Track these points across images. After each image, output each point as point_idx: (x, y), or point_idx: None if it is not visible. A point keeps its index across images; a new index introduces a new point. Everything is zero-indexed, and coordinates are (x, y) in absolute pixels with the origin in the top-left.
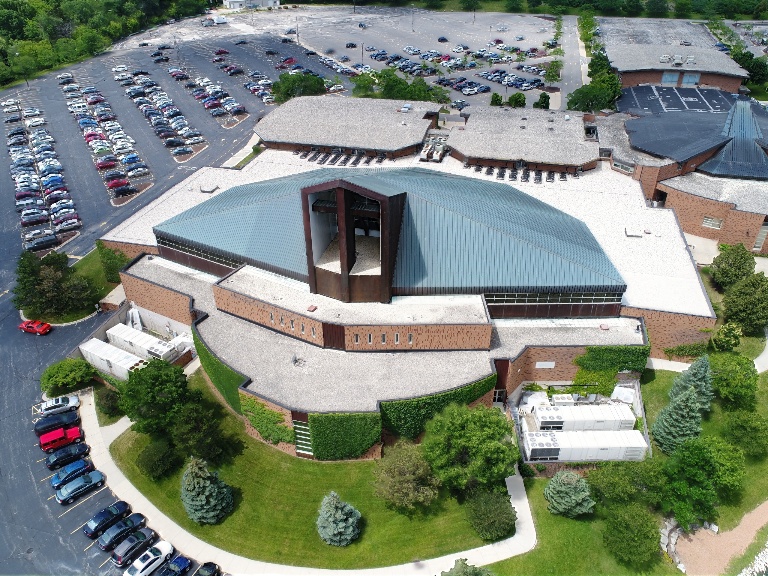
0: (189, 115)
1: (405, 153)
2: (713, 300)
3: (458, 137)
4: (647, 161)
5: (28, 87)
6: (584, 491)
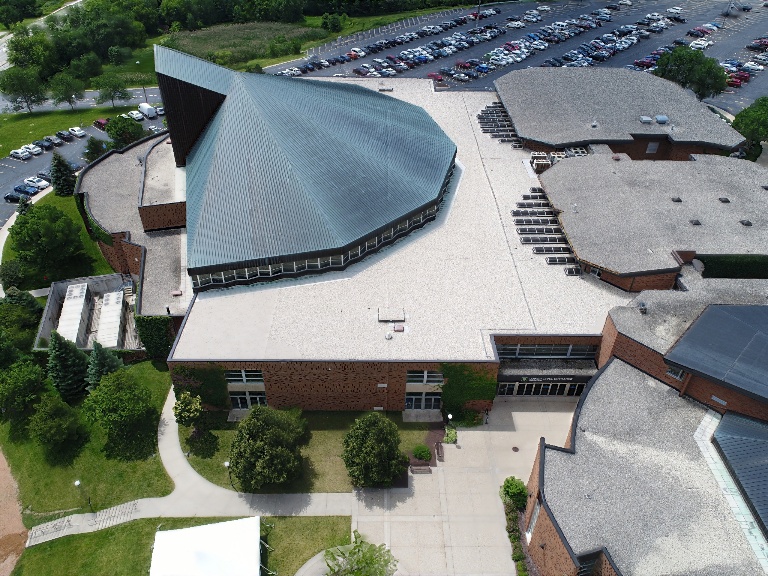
0: (608, 62)
1: (541, 149)
2: (337, 449)
3: (587, 161)
4: (633, 317)
5: (581, 2)
6: (5, 303)
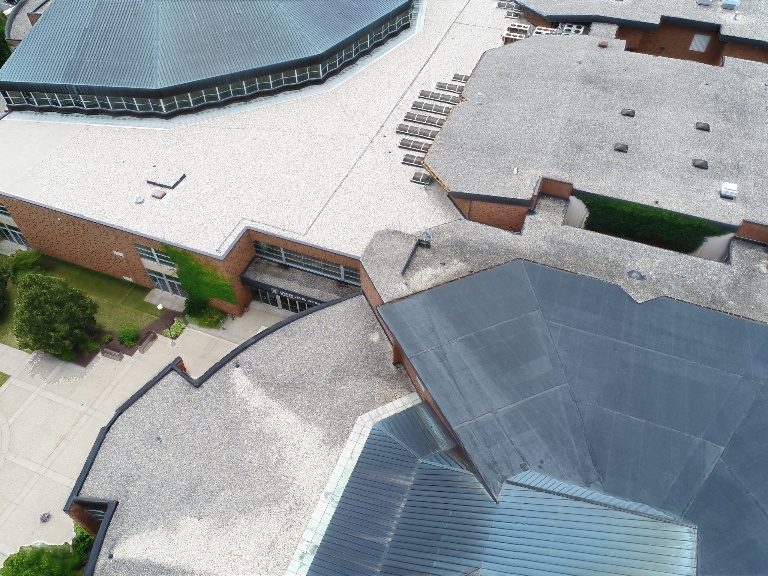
0: None
1: (538, 22)
2: None
3: (562, 42)
4: (397, 247)
5: None
6: None
